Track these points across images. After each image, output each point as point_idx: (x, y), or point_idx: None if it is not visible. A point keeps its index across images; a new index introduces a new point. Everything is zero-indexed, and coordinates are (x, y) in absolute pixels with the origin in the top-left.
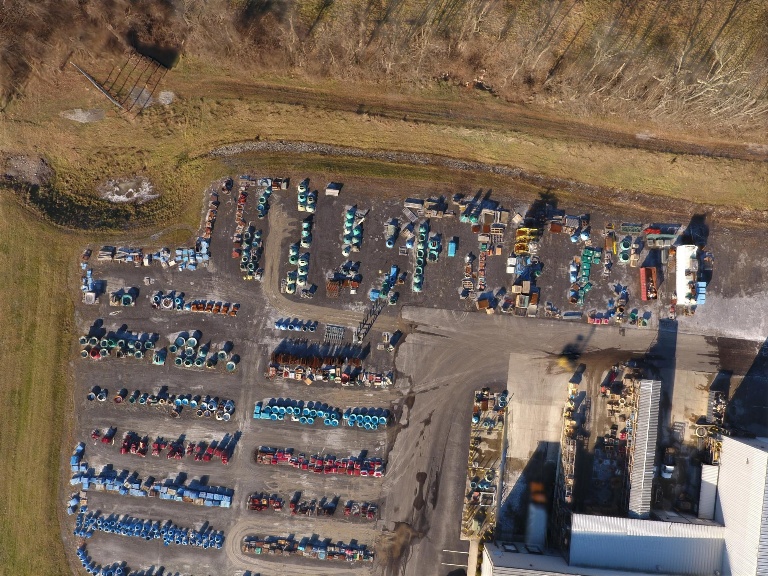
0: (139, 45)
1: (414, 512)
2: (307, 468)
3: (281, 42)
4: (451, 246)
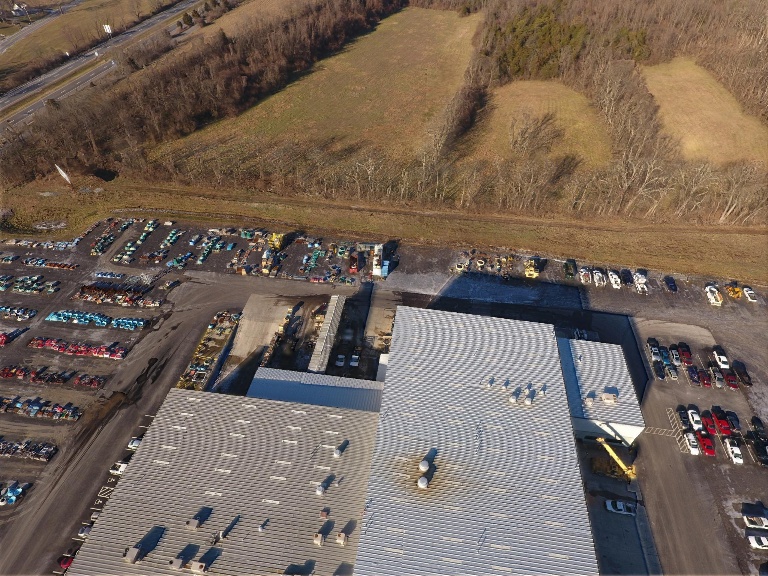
0: (97, 173)
1: (134, 385)
2: (64, 351)
3: (164, 163)
4: (230, 245)
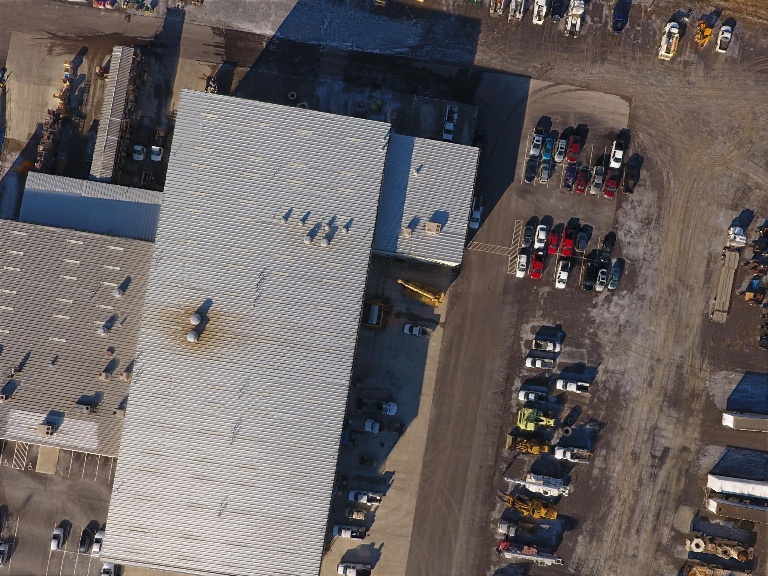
0: None
1: None
2: None
3: None
4: None
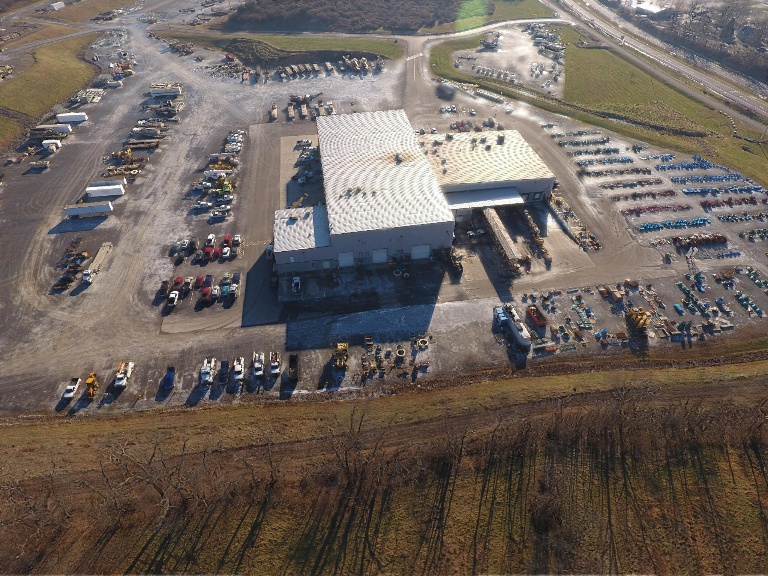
0: None
1: (593, 202)
2: None
3: None
4: (681, 308)
